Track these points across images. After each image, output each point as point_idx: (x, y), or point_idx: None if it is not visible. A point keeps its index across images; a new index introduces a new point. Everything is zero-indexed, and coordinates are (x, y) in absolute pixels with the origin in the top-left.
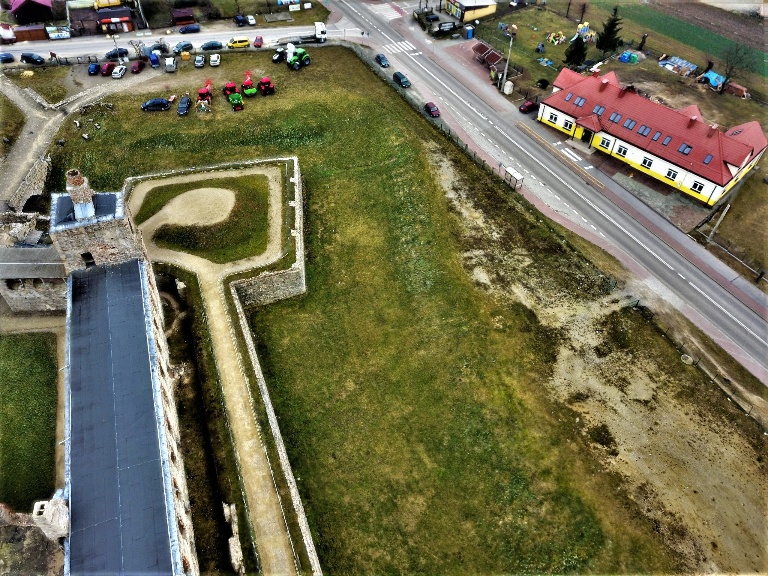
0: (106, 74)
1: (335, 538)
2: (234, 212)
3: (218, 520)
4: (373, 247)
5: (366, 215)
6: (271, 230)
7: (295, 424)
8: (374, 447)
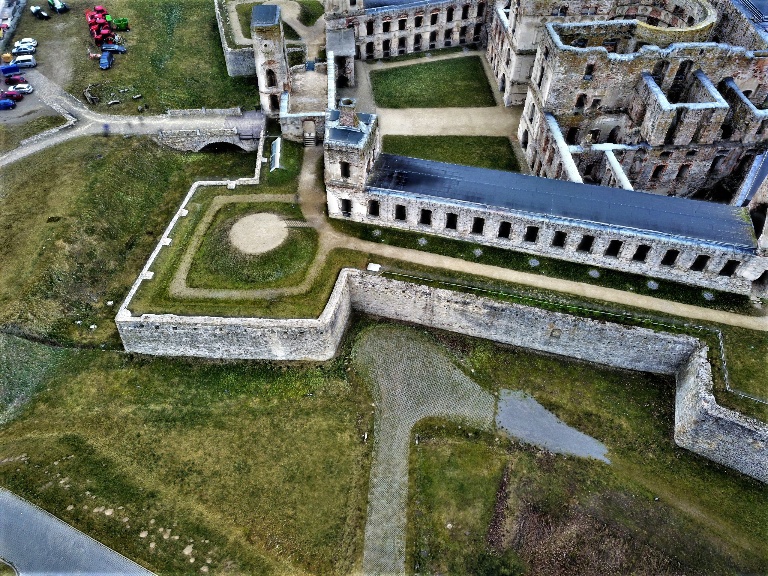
0: (21, 97)
1: None
2: None
3: None
4: None
5: None
6: None
7: None
8: None
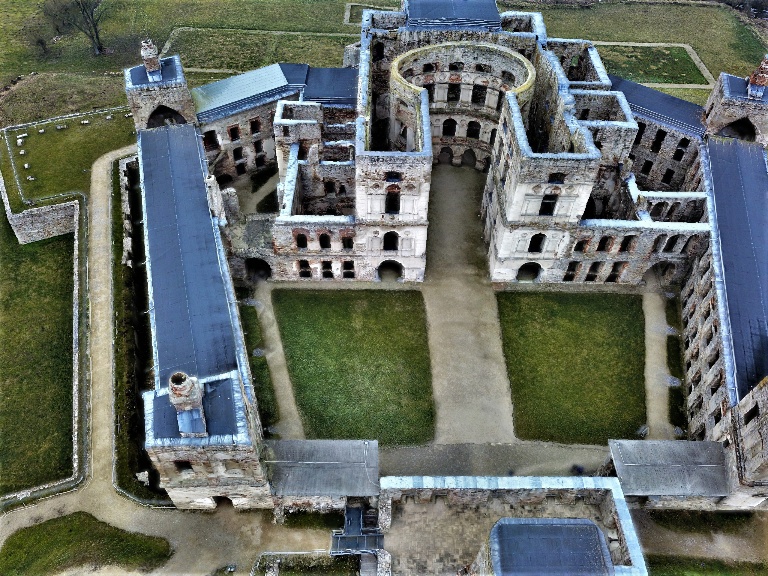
0: None
1: (66, 278)
2: None
3: (142, 271)
4: None
5: None
6: None
7: (67, 356)
8: (4, 334)
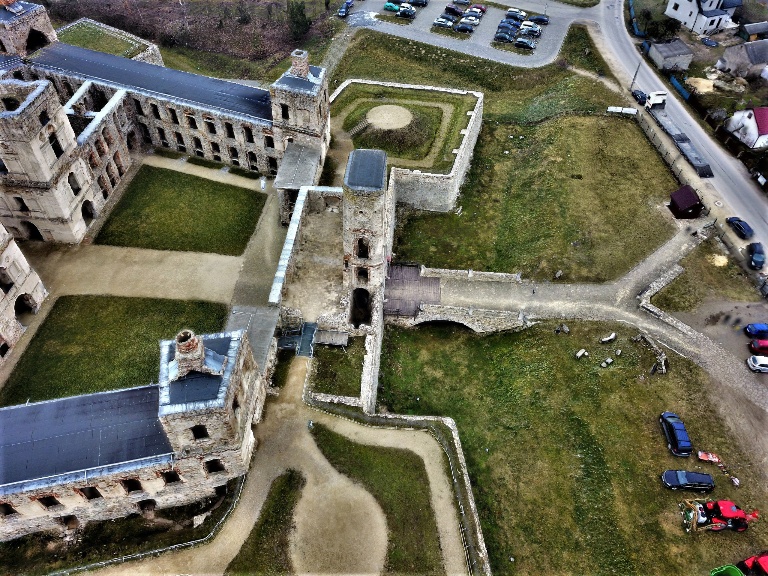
0: (753, 349)
1: None
2: None
3: None
4: None
5: None
6: None
7: None
8: None
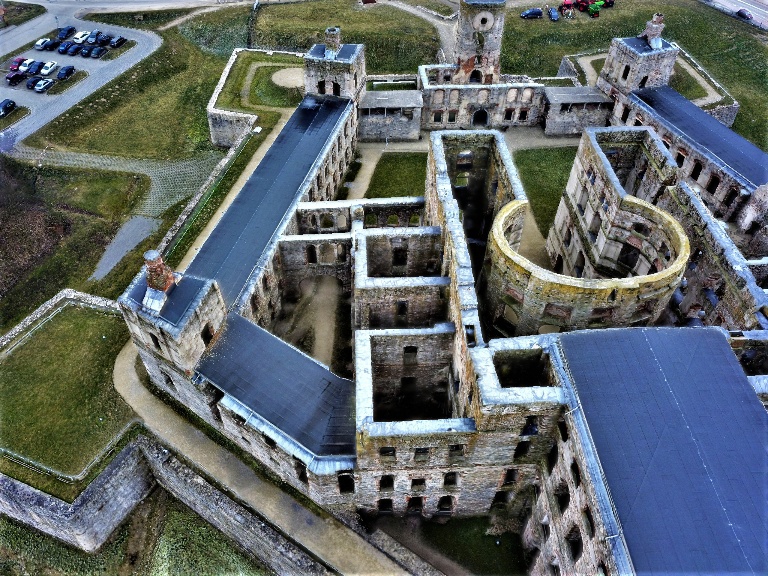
0: None
1: None
2: (676, 70)
3: None
4: (761, 100)
5: (739, 82)
6: (701, 83)
7: None
8: None
